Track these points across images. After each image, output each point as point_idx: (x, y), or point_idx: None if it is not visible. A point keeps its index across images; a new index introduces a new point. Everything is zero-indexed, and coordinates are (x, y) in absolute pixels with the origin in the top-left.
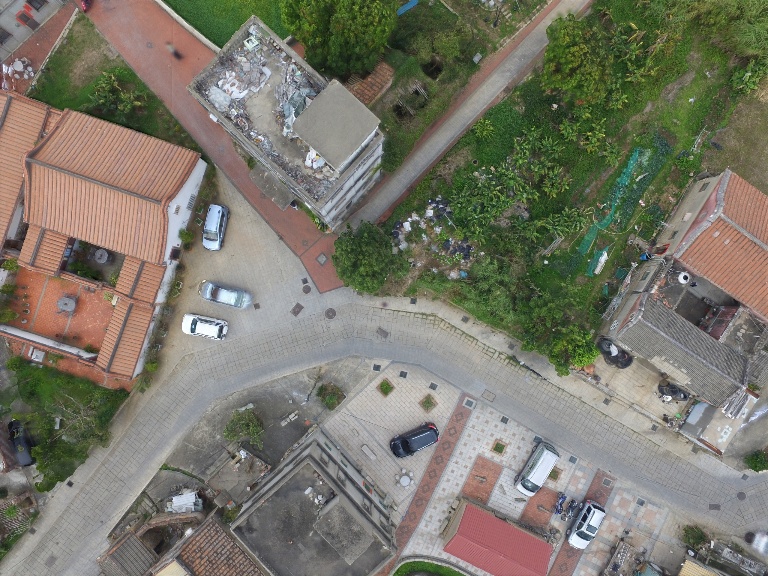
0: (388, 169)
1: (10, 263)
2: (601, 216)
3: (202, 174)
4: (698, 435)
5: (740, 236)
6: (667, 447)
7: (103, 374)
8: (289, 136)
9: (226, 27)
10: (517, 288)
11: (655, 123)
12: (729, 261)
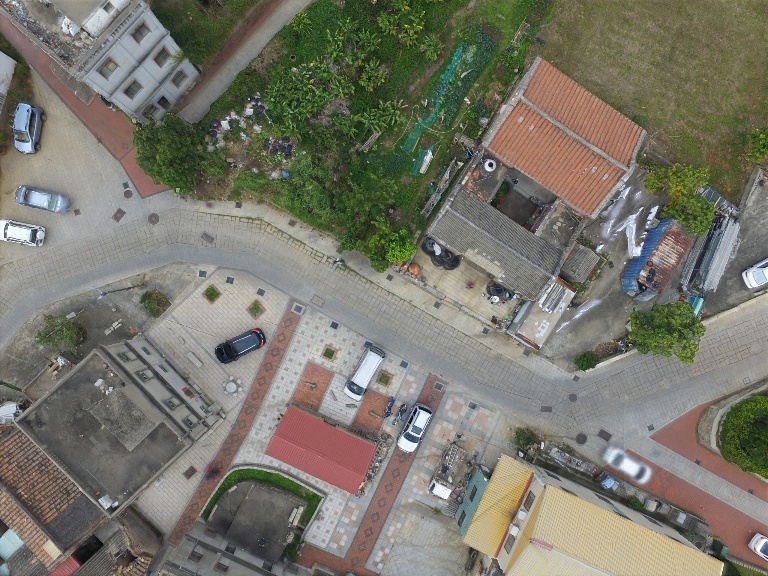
0: (195, 60)
1: None
2: (425, 114)
3: (11, 72)
4: (516, 330)
5: (543, 121)
6: (498, 350)
7: None
8: (44, 1)
9: None
10: (334, 185)
11: (480, 18)
12: (536, 148)
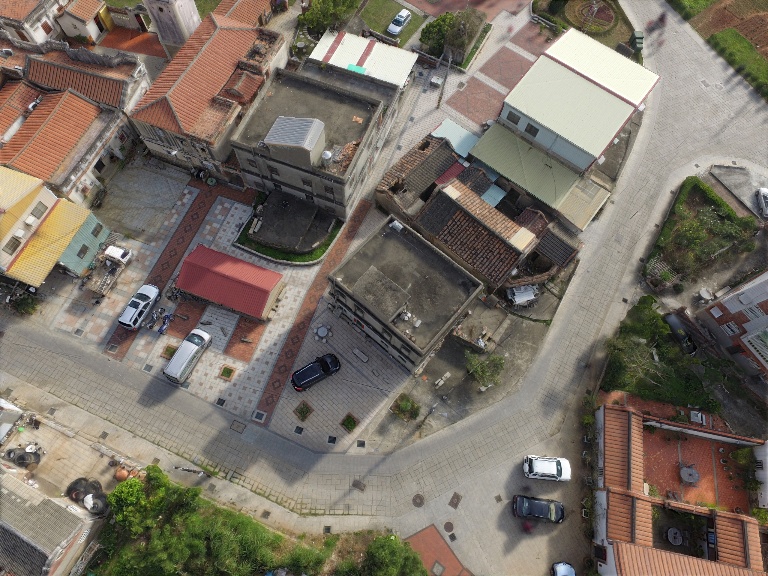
0: None
1: (763, 518)
2: None
3: None
4: (1, 414)
5: None
6: (41, 392)
7: (633, 409)
8: None
9: None
10: (204, 570)
11: None
12: None
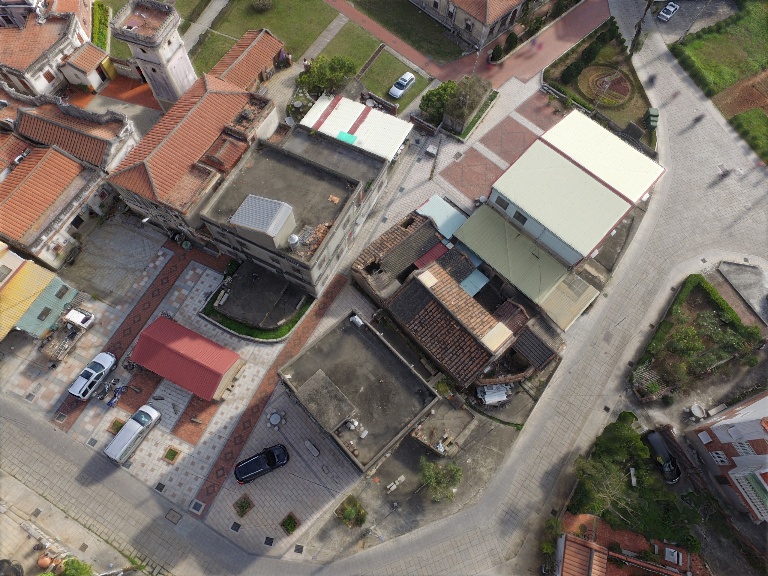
0: None
1: None
2: None
3: None
4: None
5: None
6: None
7: (597, 545)
8: None
9: None
10: None
11: None
12: None
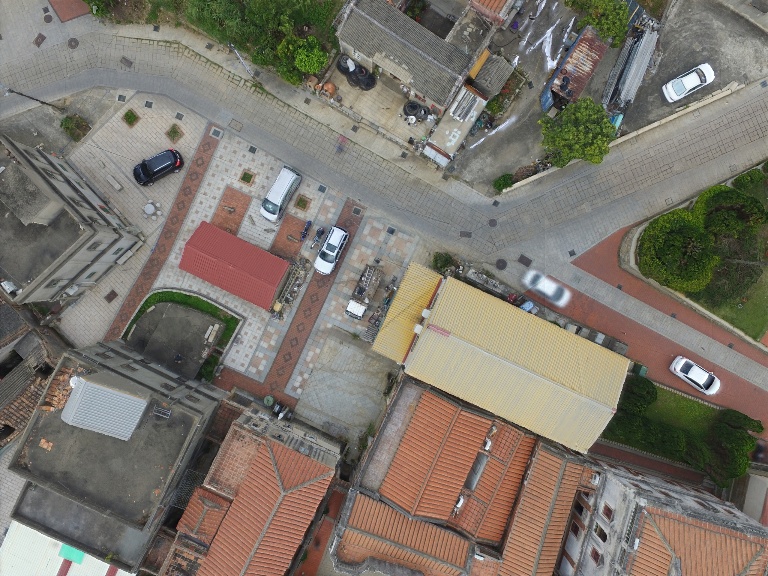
0: None
1: None
2: None
3: None
4: None
5: None
6: (417, 174)
7: None
8: None
9: None
10: None
11: None
12: None
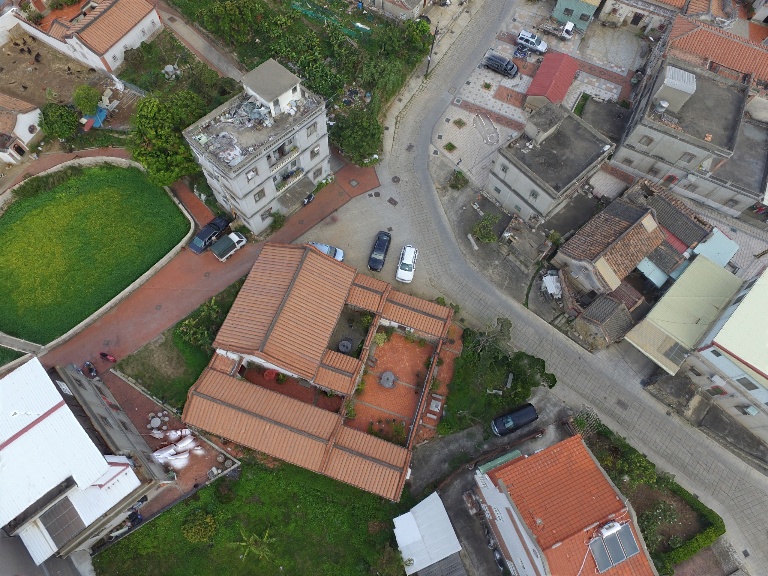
0: None
1: (349, 408)
2: None
3: None
4: None
5: None
6: (479, 7)
7: None
8: None
9: (154, 253)
10: None
11: None
12: None
